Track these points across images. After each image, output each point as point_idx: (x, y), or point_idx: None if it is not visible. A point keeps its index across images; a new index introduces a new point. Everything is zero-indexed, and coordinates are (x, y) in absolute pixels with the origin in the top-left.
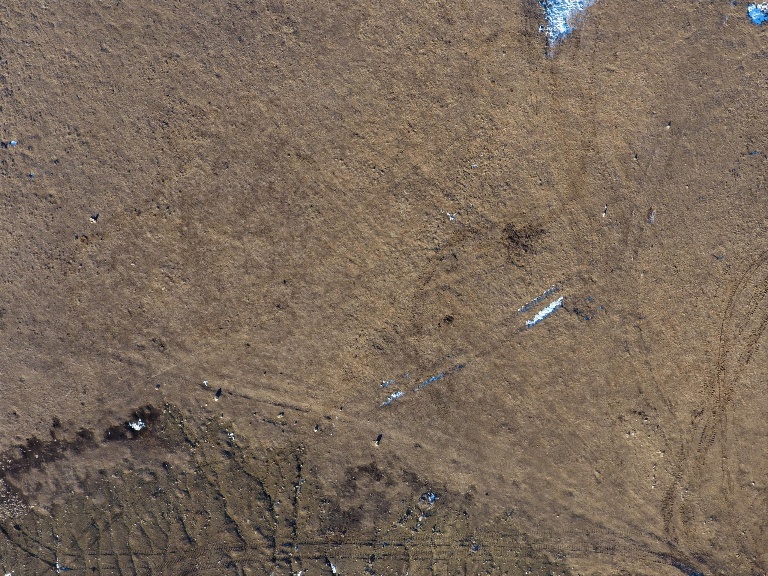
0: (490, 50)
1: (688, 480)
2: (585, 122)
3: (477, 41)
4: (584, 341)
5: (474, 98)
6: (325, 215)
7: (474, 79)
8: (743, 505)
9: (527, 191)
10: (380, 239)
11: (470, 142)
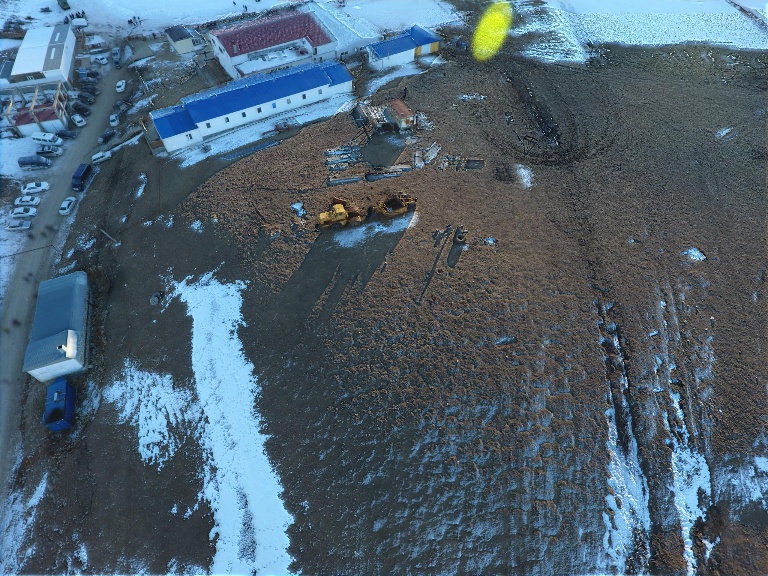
0: None
1: None
2: None
3: None
4: None
5: None
6: None
7: None
8: None
9: None
10: None
11: None
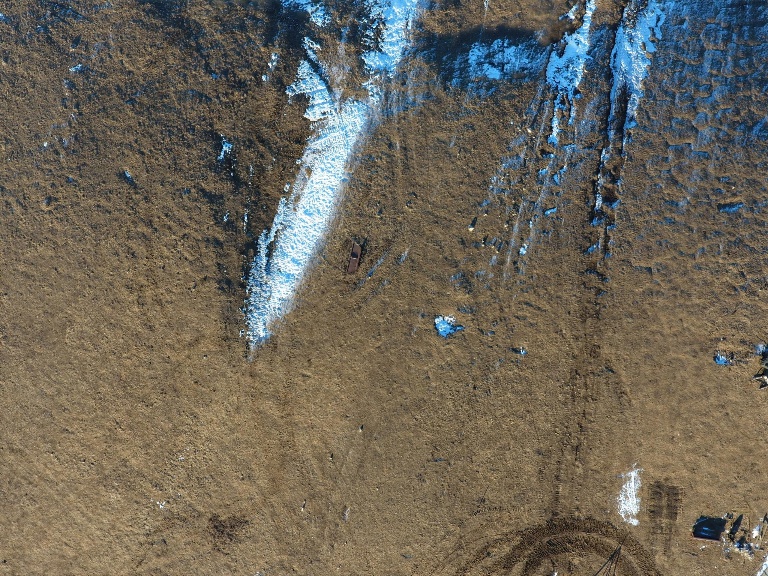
0: (192, 354)
1: None
2: (283, 423)
3: (179, 346)
4: None
5: (178, 397)
6: (39, 503)
7: (177, 380)
8: None
9: (230, 485)
10: (93, 525)
11: (176, 437)
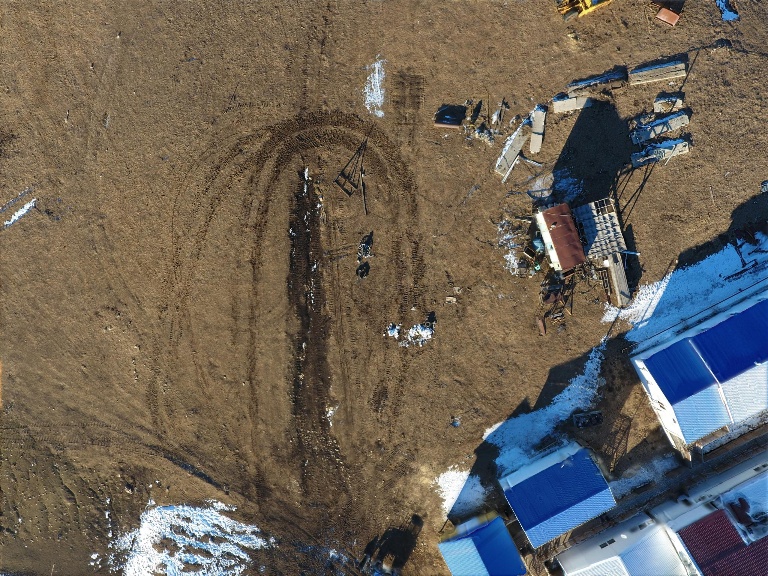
0: None
1: (166, 374)
2: (44, 33)
3: None
4: (56, 240)
5: None
6: None
7: None
8: (219, 398)
9: None
10: None
11: None
